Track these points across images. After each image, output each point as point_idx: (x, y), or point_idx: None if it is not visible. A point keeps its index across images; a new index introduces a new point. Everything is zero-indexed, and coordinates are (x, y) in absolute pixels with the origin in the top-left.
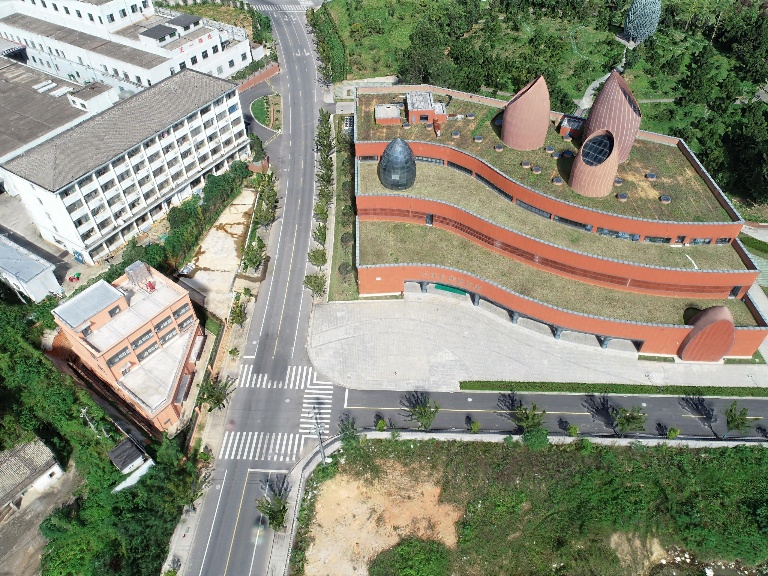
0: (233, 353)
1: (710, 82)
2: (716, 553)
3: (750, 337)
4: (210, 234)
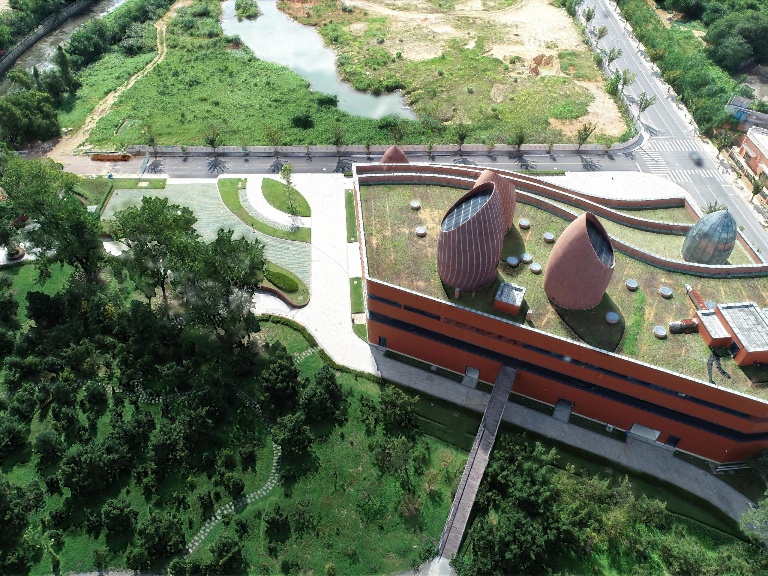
0: (738, 175)
1: None
2: None
3: None
4: None
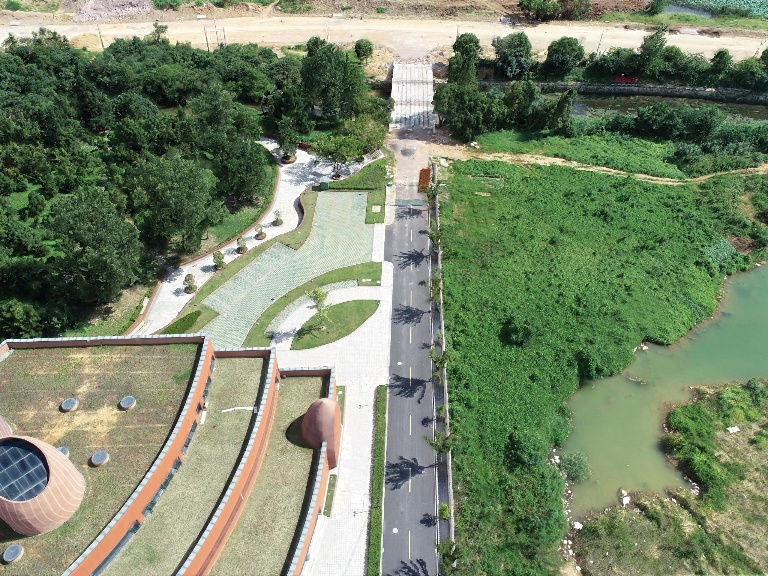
0: None
1: None
2: None
3: None
4: None
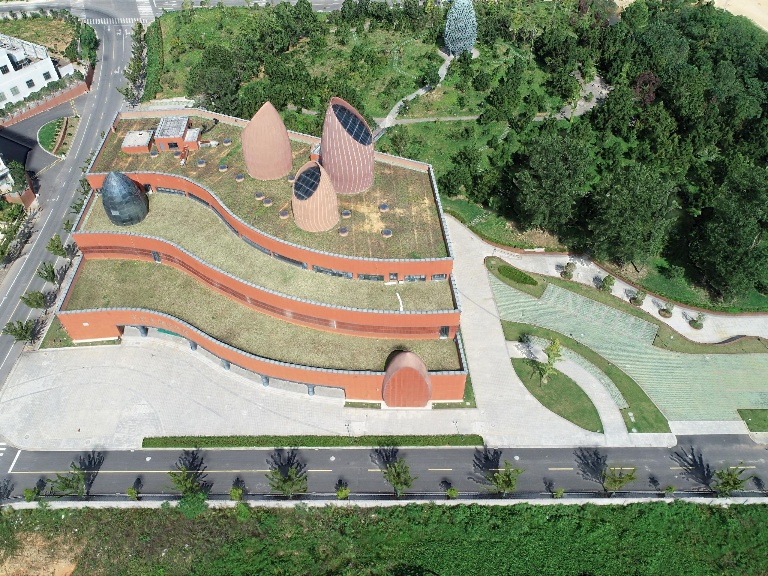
0: None
1: (514, 98)
2: None
3: (449, 382)
4: None
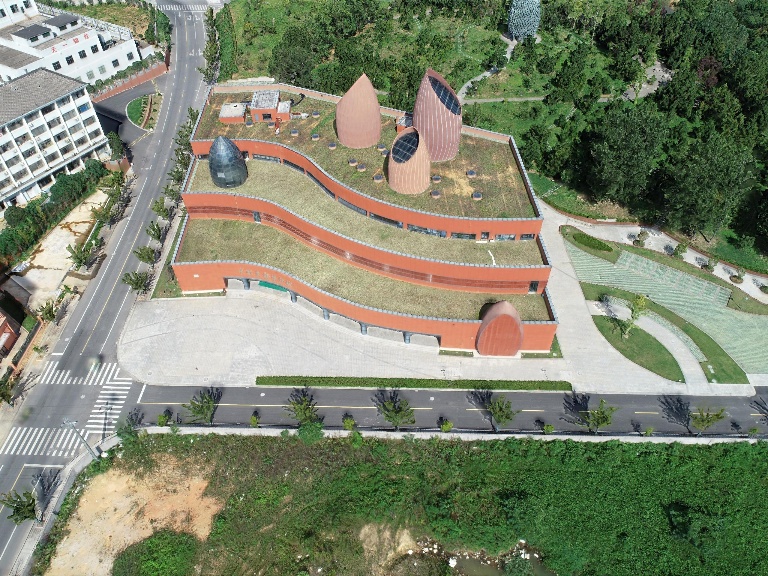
0: (37, 350)
1: (579, 80)
2: (462, 543)
3: (540, 331)
4: (53, 232)
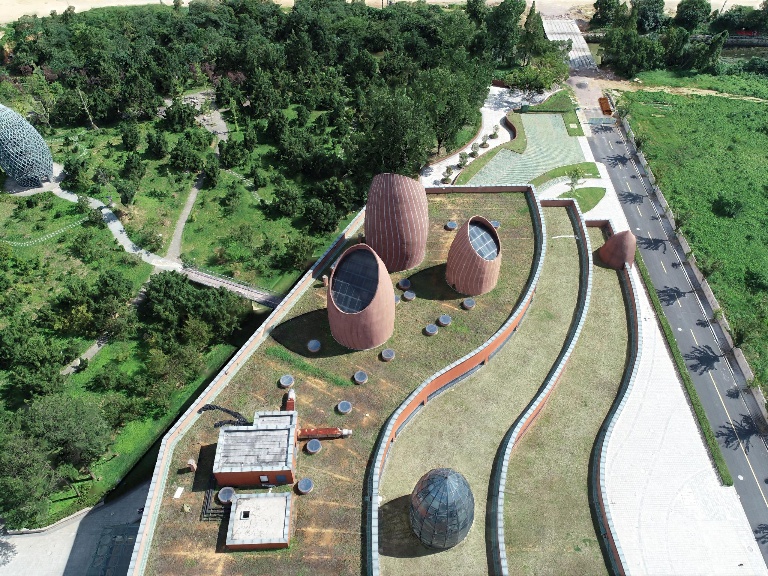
0: None
1: None
2: None
3: None
4: None
